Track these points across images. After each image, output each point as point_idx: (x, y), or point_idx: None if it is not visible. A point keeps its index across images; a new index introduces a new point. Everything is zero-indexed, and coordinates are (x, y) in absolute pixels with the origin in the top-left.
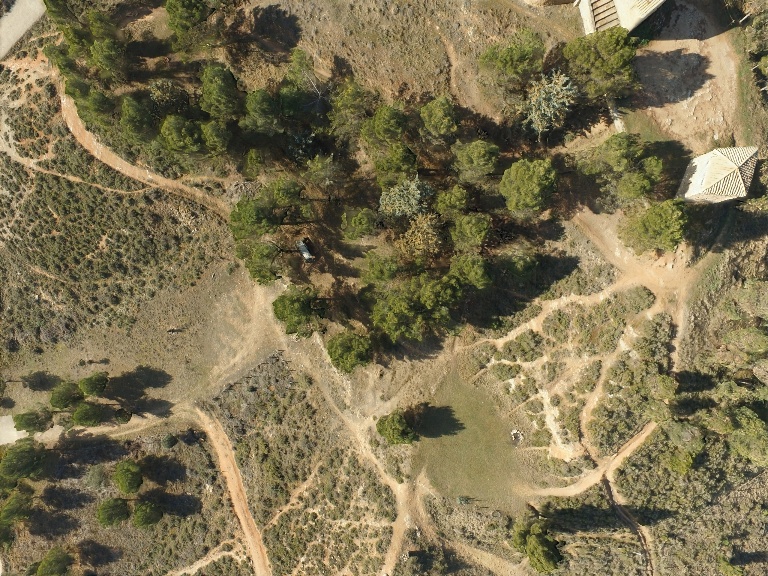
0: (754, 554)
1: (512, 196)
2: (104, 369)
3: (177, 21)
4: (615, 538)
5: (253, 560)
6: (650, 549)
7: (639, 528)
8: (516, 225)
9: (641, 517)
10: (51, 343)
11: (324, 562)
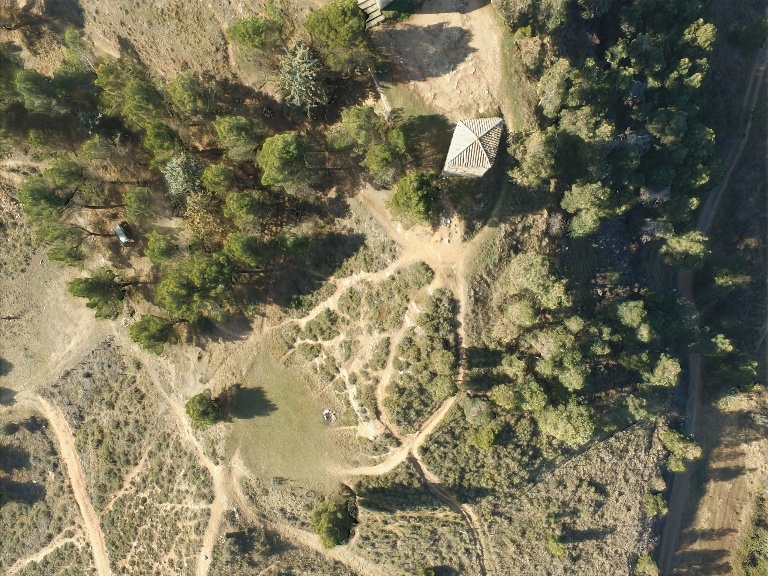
0: (587, 532)
1: (265, 171)
2: None
3: None
4: (438, 517)
5: (92, 546)
6: (477, 528)
7: (462, 507)
8: (309, 204)
9: (458, 495)
10: None
11: (152, 546)
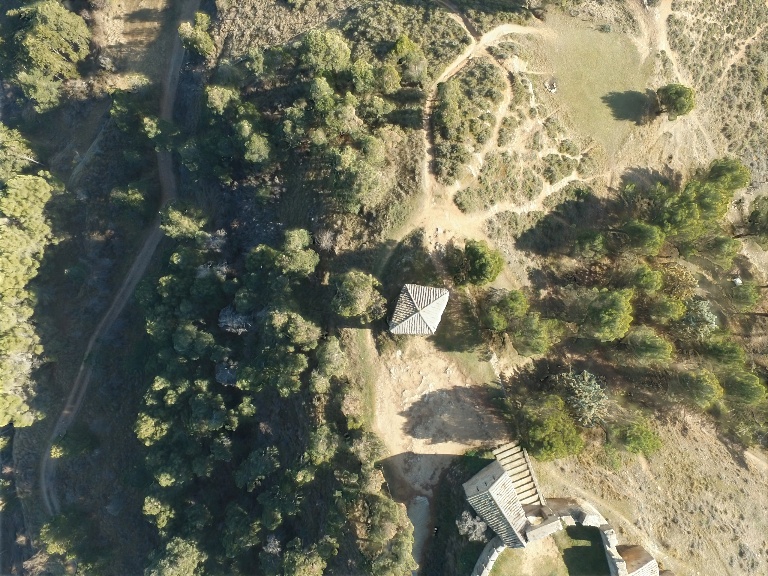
0: None
1: None
2: None
3: None
4: None
5: None
6: None
7: None
8: None
9: (428, 1)
10: None
11: None
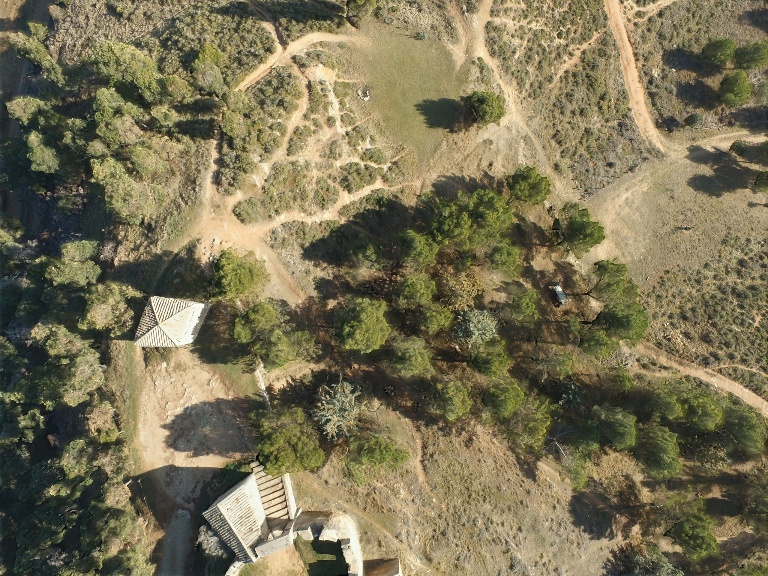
0: None
1: None
2: (753, 198)
3: None
4: None
5: (618, 0)
6: None
7: (246, 1)
8: None
9: (246, 10)
10: None
11: None
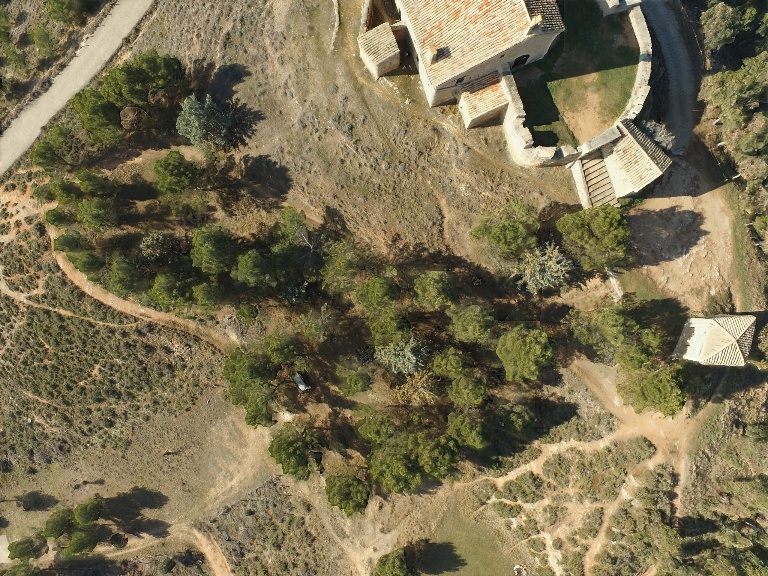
0: None
1: (509, 366)
2: (99, 489)
3: (166, 187)
4: None
5: None
6: None
7: None
8: None
9: None
10: (45, 464)
11: None
